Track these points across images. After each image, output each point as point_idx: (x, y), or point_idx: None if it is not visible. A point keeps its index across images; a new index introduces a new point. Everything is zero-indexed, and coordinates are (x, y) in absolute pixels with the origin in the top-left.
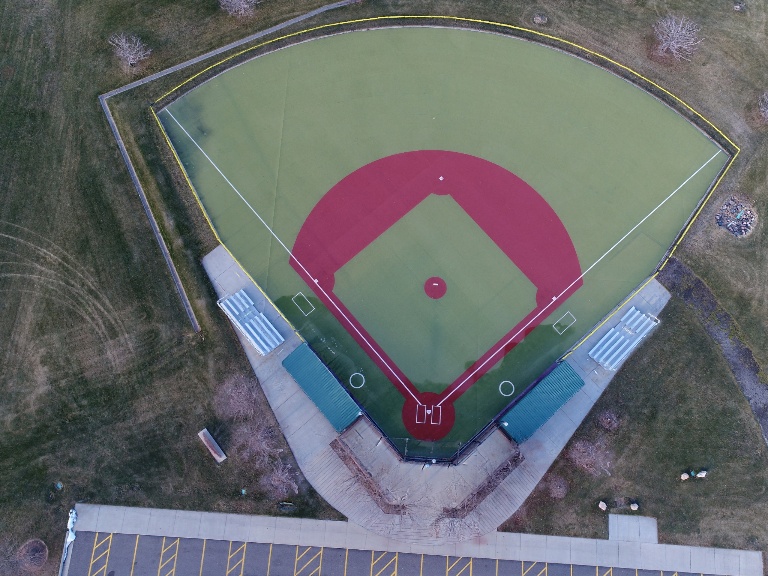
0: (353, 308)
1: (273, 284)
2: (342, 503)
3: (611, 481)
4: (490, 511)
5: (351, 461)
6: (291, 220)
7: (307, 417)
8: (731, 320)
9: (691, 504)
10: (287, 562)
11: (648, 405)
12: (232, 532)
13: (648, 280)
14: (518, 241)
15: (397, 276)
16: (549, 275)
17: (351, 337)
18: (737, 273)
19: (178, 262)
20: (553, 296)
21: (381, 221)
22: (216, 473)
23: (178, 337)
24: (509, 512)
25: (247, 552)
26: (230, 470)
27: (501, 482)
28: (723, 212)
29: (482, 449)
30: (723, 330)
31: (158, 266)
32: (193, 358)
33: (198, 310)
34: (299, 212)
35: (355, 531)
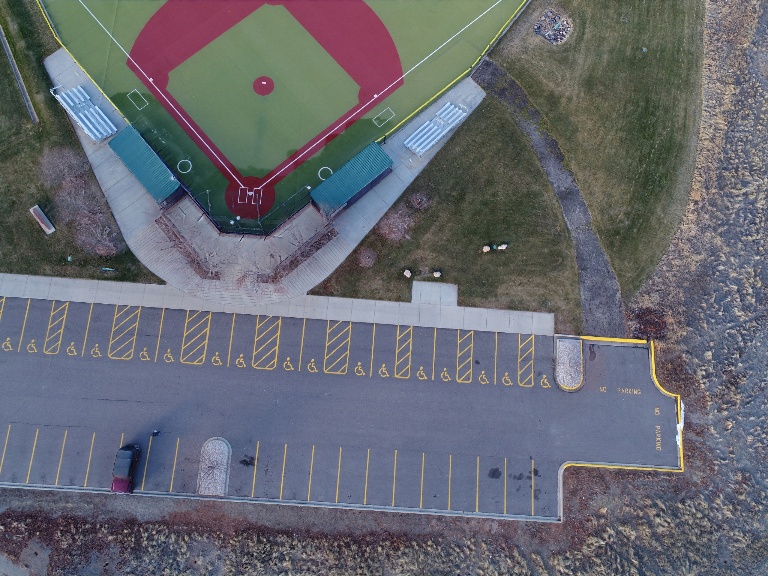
0: (184, 103)
1: (110, 82)
2: (162, 270)
3: (417, 253)
4: (301, 278)
5: (174, 235)
6: (130, 26)
7: (135, 197)
8: (541, 115)
9: (491, 273)
10: (106, 319)
11: (457, 188)
12: (56, 293)
13: (460, 75)
14: (345, 46)
15: (228, 75)
16: (372, 75)
17: (181, 128)
18: (549, 74)
19: (20, 62)
20: (374, 94)
21: (216, 27)
22: (44, 243)
23: (17, 127)
24: (319, 279)
25: (69, 310)
26: (58, 240)
27: (314, 253)
28: (541, 23)
29: (297, 224)
30: (533, 124)
31: (1, 66)
32: (30, 145)
33: (37, 104)
34: (138, 19)
35: (172, 293)
